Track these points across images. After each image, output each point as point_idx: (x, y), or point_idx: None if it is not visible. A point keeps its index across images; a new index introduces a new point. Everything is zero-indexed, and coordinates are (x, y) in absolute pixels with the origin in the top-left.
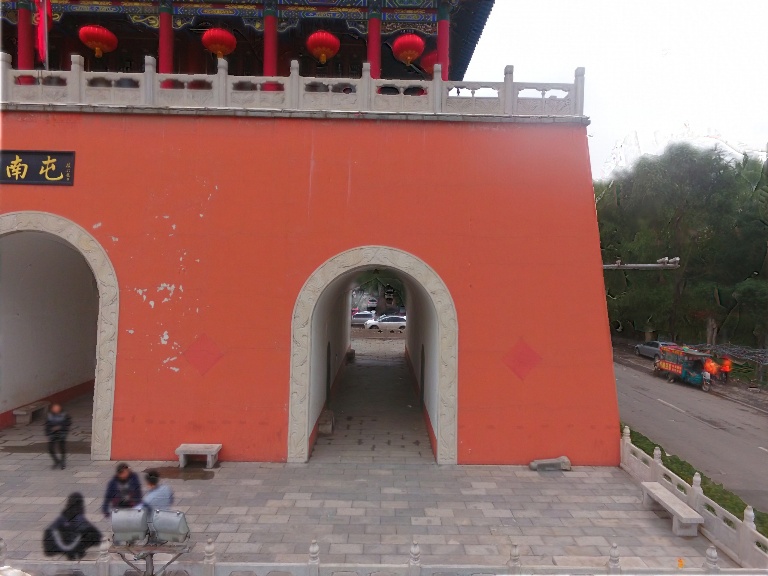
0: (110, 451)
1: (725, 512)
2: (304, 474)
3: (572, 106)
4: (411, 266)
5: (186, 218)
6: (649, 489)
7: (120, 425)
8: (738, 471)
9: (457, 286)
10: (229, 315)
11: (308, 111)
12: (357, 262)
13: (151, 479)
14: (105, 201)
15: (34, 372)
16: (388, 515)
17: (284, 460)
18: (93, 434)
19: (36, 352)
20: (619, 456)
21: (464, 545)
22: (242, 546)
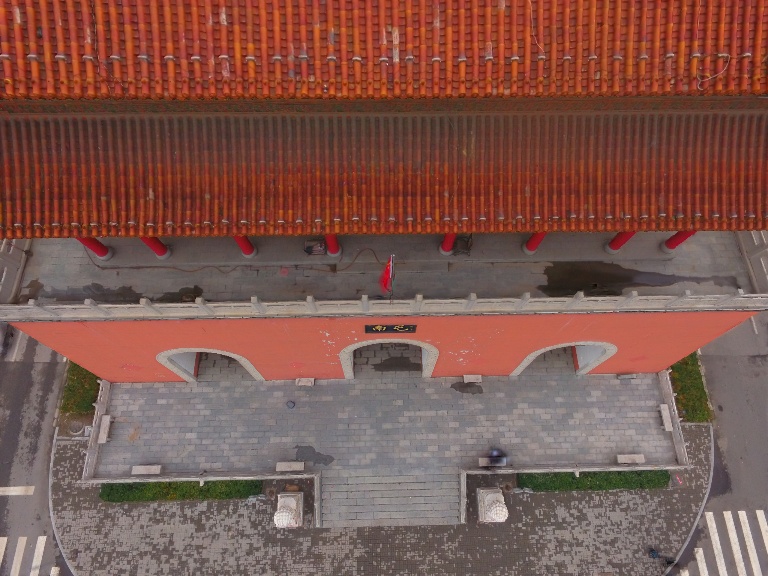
0: None
1: (681, 434)
2: (520, 387)
3: (767, 301)
4: None
5: None
6: (662, 411)
7: None
8: None
9: None
10: None
11: (578, 312)
12: None
13: (459, 394)
14: None
15: None
16: (560, 419)
17: (508, 375)
18: (423, 374)
19: None
20: (660, 371)
21: (587, 437)
22: (515, 440)
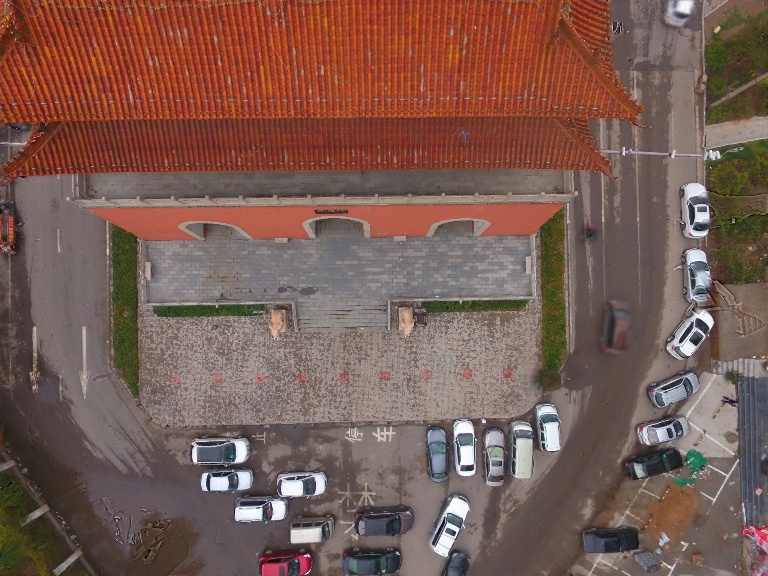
0: None
1: None
2: None
3: None
4: None
5: None
6: None
7: None
8: None
9: None
10: None
11: None
12: None
13: None
14: None
15: None
16: None
17: None
18: None
19: None
20: None
21: None
22: None
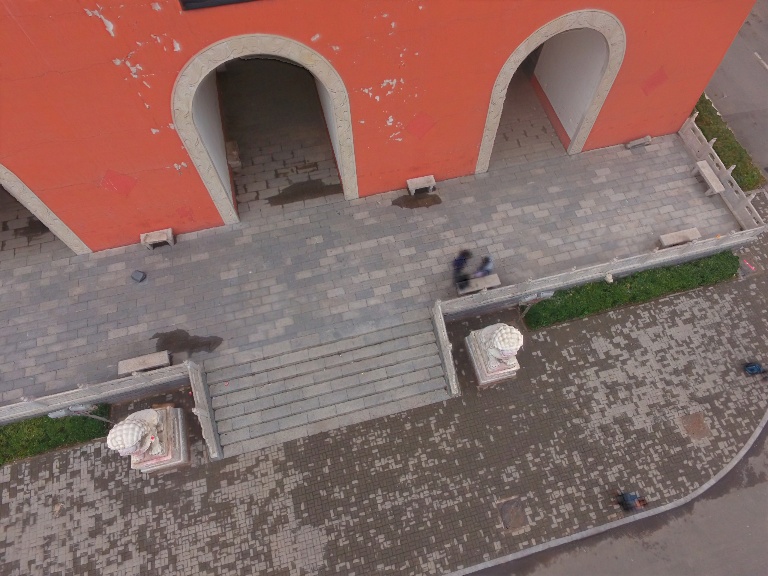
0: (358, 194)
1: (739, 189)
2: (494, 185)
3: None
4: (604, 24)
5: (404, 12)
6: (701, 169)
7: (362, 179)
8: (735, 91)
9: (634, 34)
10: (442, 93)
11: None
12: (559, 29)
13: (406, 211)
14: (317, 9)
15: (215, 124)
16: (562, 212)
17: (472, 173)
18: (345, 188)
19: (209, 108)
20: (681, 127)
21: (609, 227)
22: (505, 253)
